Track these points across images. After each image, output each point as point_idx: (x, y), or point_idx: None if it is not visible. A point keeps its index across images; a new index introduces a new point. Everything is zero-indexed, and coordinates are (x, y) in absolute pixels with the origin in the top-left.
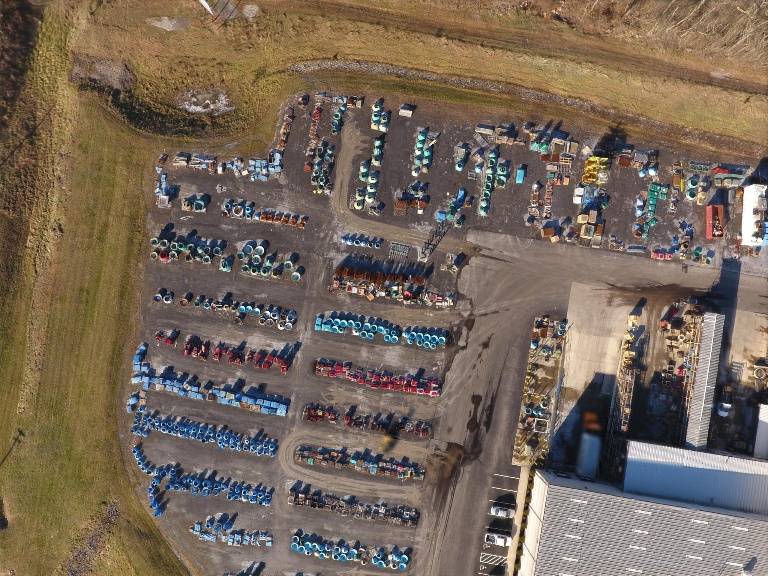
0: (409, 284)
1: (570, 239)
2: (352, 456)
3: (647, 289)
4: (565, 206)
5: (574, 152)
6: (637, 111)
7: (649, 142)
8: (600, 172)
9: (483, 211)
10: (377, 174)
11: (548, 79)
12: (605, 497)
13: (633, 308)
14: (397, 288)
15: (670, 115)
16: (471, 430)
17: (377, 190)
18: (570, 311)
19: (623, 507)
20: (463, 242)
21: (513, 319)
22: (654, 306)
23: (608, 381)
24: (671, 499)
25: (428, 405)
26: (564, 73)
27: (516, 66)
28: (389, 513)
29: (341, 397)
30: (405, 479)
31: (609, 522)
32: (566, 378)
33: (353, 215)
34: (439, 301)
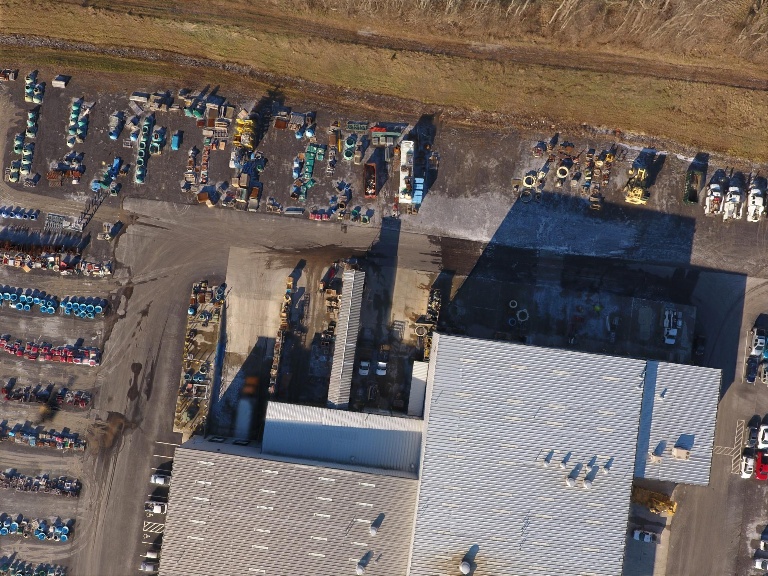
0: (66, 254)
1: (225, 203)
2: (13, 429)
3: (306, 251)
4: (222, 171)
5: (230, 116)
6: (294, 73)
7: (307, 104)
8: (242, 134)
9: (136, 178)
10: (32, 146)
11: (203, 45)
12: (231, 458)
13: (292, 270)
14: (53, 259)
15: (326, 76)
16: (132, 398)
17: (32, 162)
18: (229, 275)
19: (250, 467)
20: (120, 210)
21: (171, 286)
22: (314, 267)
23: (272, 345)
24: (310, 458)
25: (88, 375)
26: (216, 38)
27: (168, 33)
28: (50, 485)
29: (0, 370)
30: (66, 450)
31: (236, 483)
32: (229, 343)
33: (9, 188)
34: (96, 270)
